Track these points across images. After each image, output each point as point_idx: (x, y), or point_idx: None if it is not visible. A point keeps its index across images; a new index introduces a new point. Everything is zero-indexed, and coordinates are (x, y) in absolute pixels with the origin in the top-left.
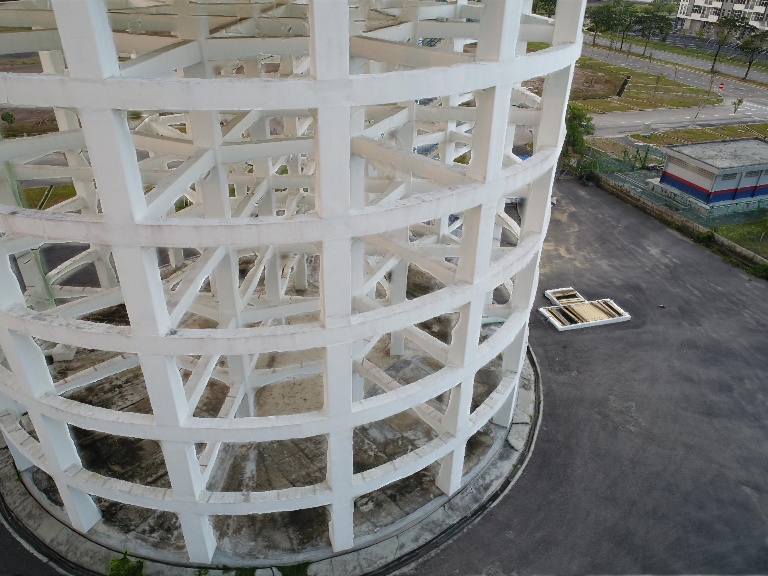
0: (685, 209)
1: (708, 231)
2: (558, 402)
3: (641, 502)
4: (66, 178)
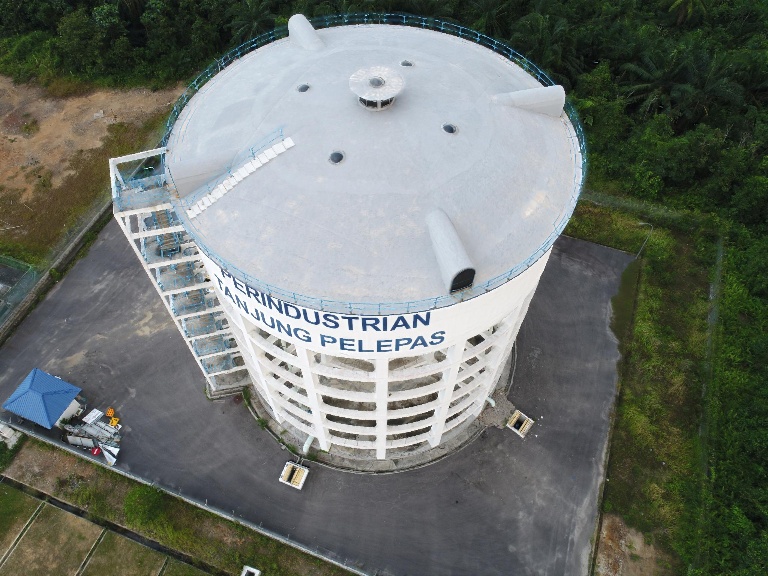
0: (4, 301)
1: (50, 271)
2: None
3: None
4: None
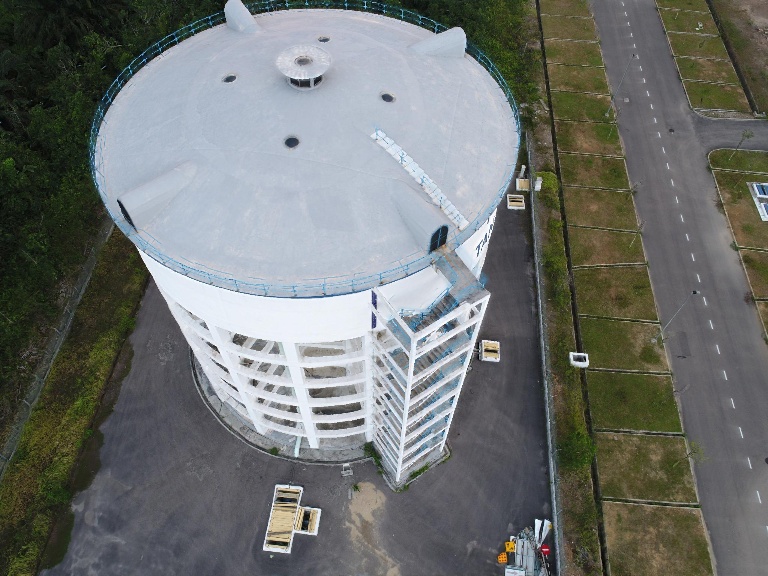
0: None
1: None
2: (225, 439)
3: (156, 432)
4: (660, 241)
